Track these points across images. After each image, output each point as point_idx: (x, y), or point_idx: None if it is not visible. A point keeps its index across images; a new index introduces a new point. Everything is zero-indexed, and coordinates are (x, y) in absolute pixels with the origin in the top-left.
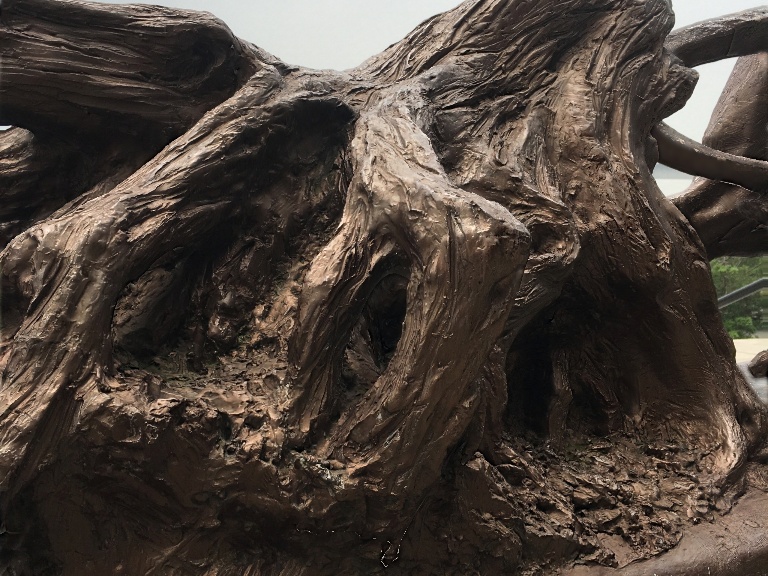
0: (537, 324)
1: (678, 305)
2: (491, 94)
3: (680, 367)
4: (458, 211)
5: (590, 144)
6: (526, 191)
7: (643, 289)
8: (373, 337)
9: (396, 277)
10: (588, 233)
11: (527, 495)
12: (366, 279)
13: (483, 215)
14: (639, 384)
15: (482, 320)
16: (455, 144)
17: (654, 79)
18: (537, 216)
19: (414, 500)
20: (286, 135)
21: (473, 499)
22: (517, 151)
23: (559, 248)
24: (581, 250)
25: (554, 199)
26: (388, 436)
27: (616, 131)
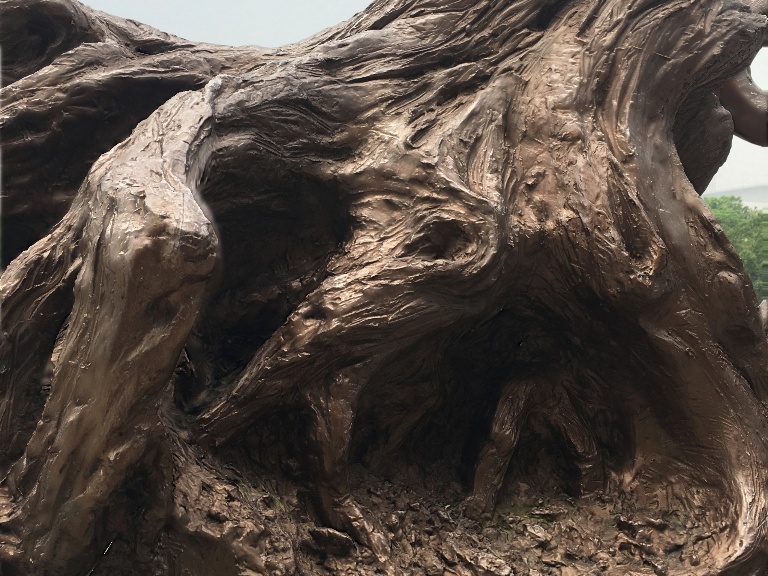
0: (504, 347)
1: (683, 331)
2: (448, 62)
3: (688, 414)
4: (118, 204)
5: (563, 119)
6: (438, 180)
7: (616, 308)
8: (198, 357)
9: (254, 285)
10: (538, 234)
11: (349, 571)
12: (57, 289)
13: (143, 209)
14: (636, 432)
15: (131, 347)
16: (359, 124)
17: (690, 31)
18: (444, 212)
19: (57, 572)
20: (102, 119)
21: (209, 573)
22: (449, 131)
23: (467, 253)
24: (531, 255)
25: (487, 190)
26: (33, 487)
27: (611, 101)
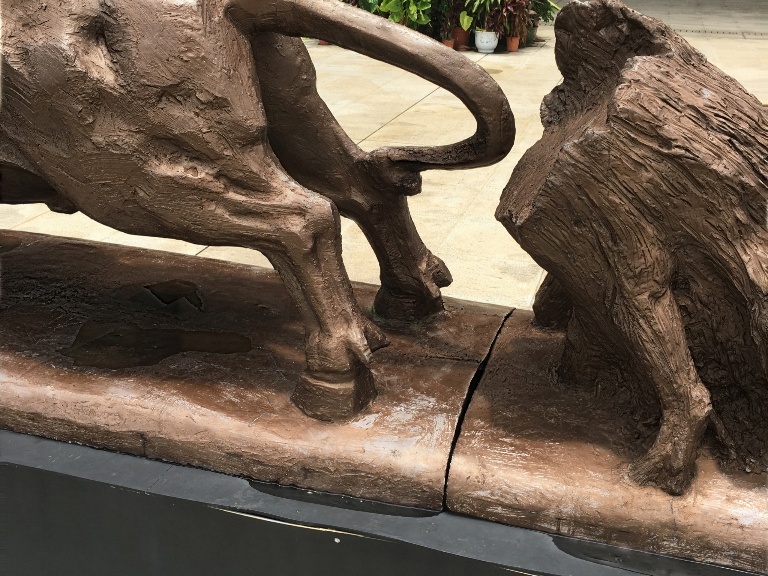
0: None
1: None
2: None
3: None
4: None
5: None
6: None
7: None
8: None
9: None
10: None
11: None
12: None
13: None
14: None
15: None
16: None
17: None
18: None
19: None
20: None
21: None
22: None
23: None
24: None
25: None
26: None
27: None
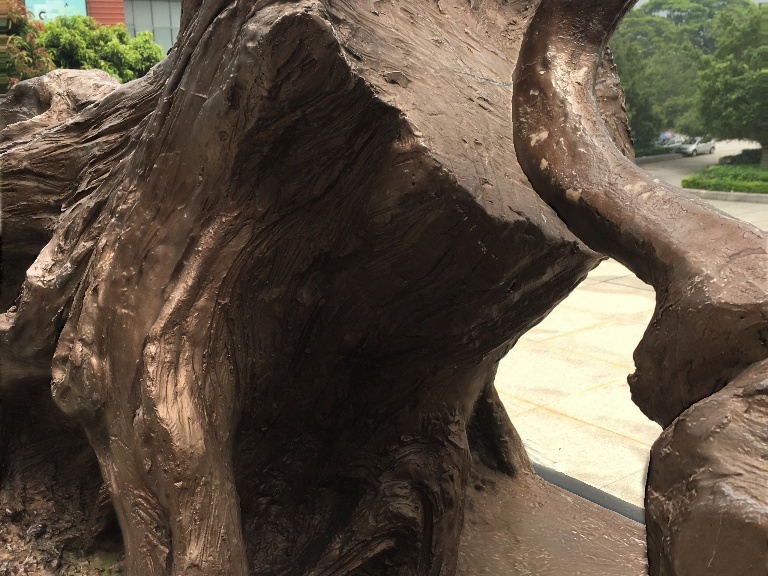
0: None
1: None
2: None
3: None
4: None
5: None
6: None
7: None
8: None
9: None
10: None
11: None
12: None
13: None
14: None
15: None
16: None
17: (225, 53)
18: None
19: None
20: None
21: None
22: None
23: None
24: None
25: None
26: None
27: None
